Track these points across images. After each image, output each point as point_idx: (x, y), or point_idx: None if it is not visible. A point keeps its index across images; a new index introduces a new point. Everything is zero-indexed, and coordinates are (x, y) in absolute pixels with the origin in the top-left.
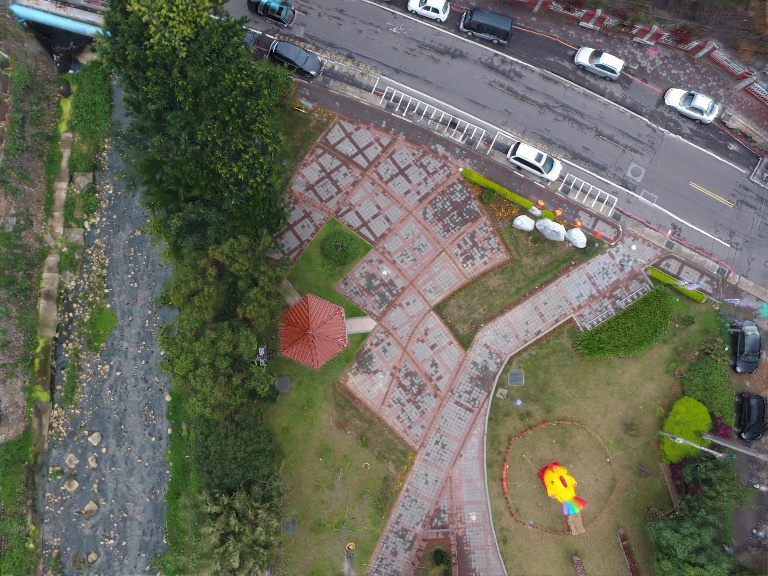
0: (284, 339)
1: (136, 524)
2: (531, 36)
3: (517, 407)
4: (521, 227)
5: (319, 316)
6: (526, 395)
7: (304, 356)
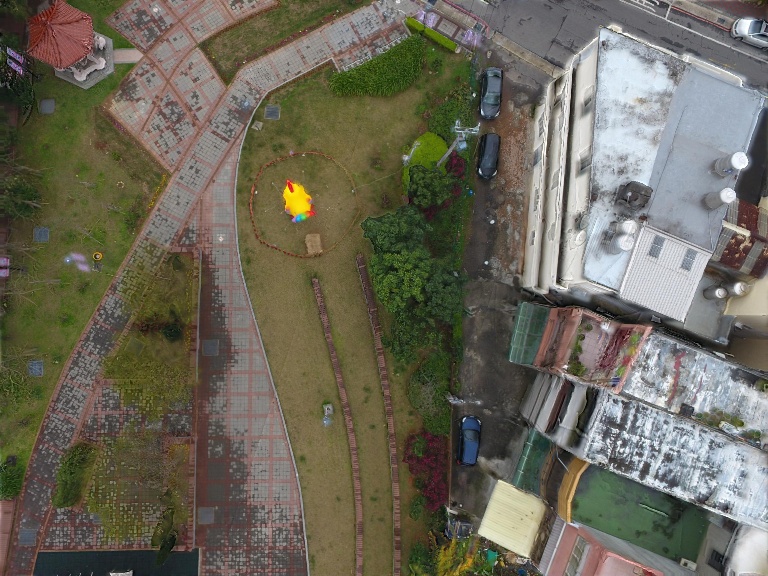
0: (31, 39)
1: None
2: None
3: (271, 139)
4: None
5: (64, 17)
6: (280, 128)
7: (48, 55)
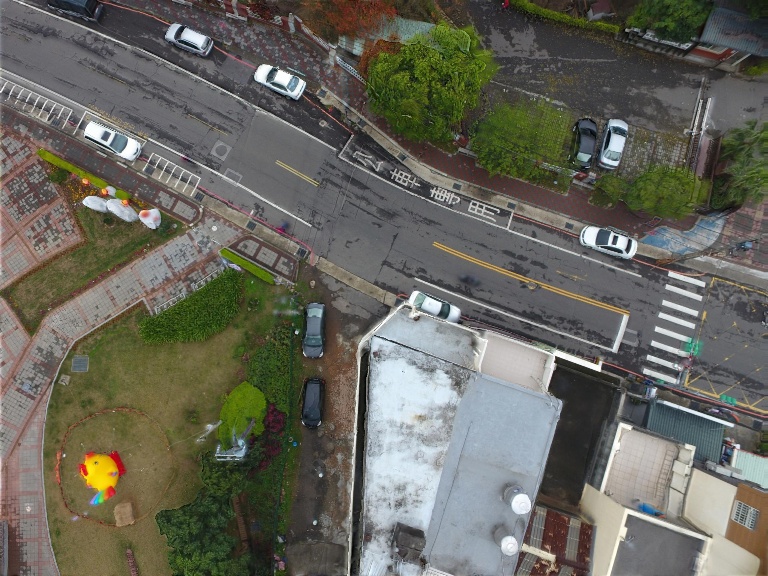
0: None
1: None
2: (127, 13)
3: (79, 394)
4: None
5: None
6: (89, 381)
7: None
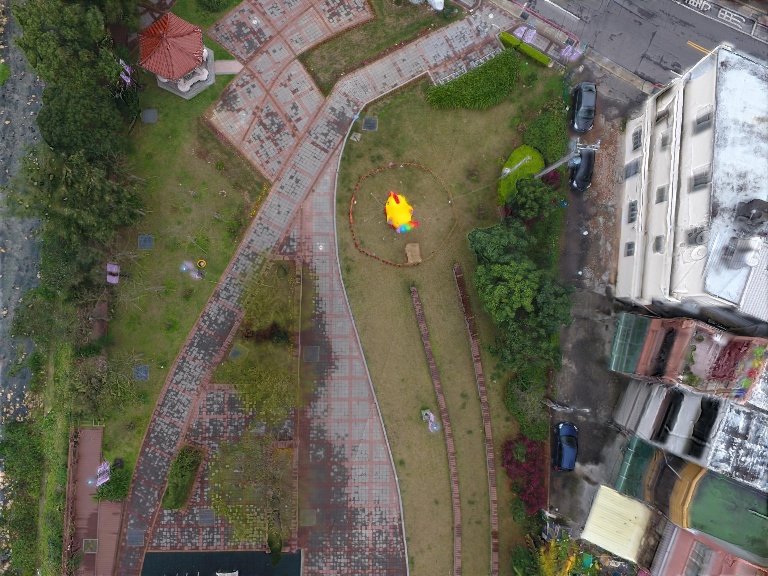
0: (144, 51)
1: (13, 260)
2: None
3: (369, 150)
4: None
5: (177, 30)
6: (378, 139)
7: (161, 67)
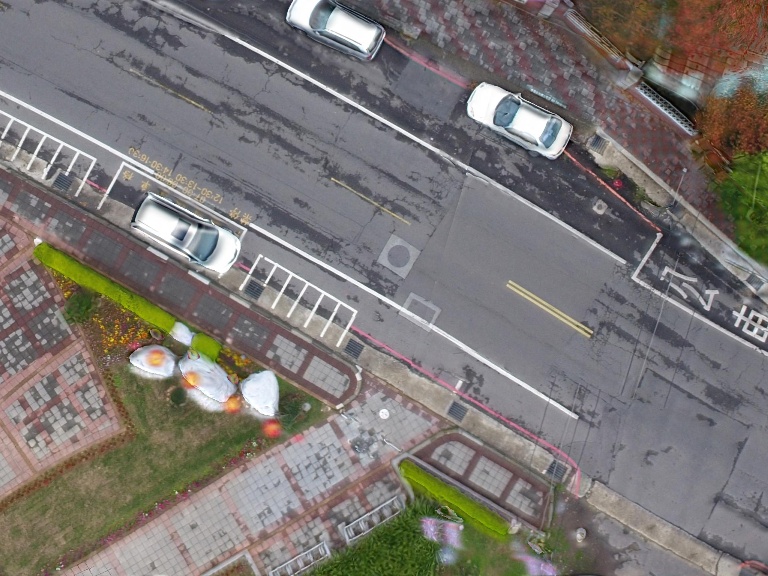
0: None
1: None
2: None
3: None
4: (145, 370)
5: None
6: None
7: None
